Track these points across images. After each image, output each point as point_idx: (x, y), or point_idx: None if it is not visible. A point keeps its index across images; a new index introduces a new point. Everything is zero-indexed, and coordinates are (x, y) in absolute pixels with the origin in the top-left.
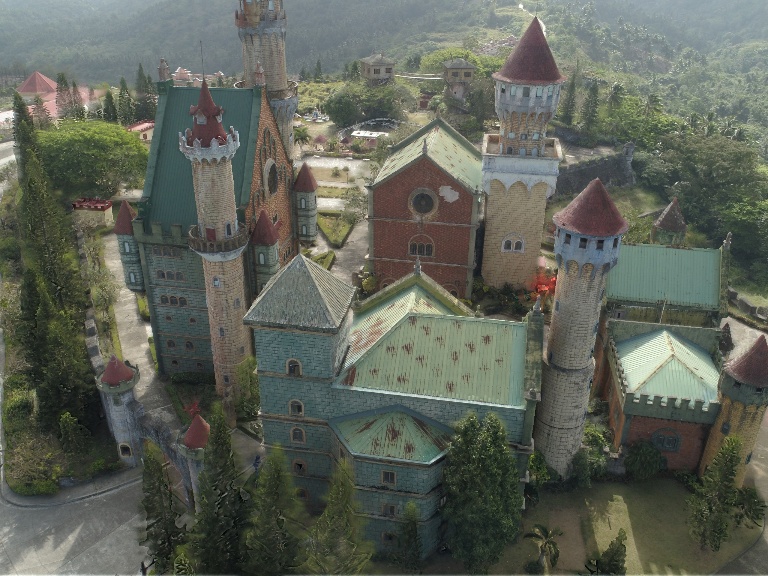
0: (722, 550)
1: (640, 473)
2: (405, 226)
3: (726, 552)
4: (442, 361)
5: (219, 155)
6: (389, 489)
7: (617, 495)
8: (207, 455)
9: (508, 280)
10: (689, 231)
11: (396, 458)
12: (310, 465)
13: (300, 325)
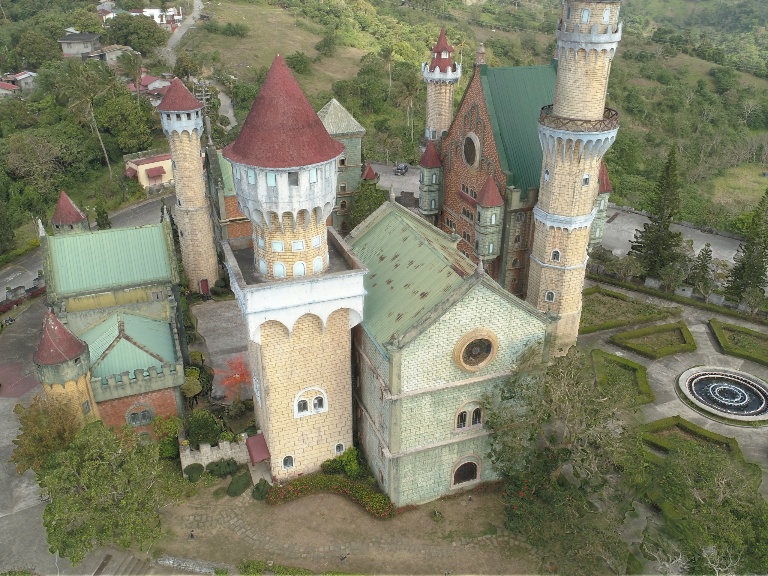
0: None
1: None
2: None
3: None
4: None
5: None
6: None
7: None
8: None
9: None
10: None
11: None
12: None
13: None
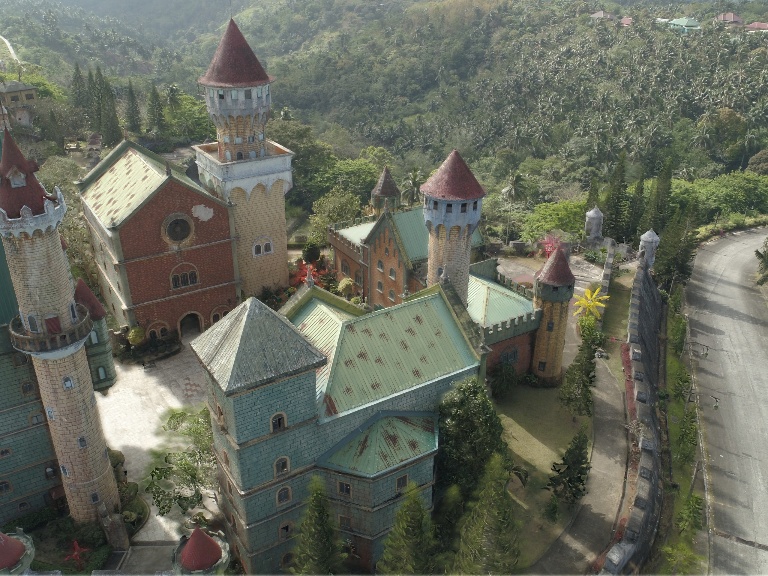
0: (583, 416)
1: (509, 389)
2: (162, 260)
3: (586, 416)
4: (397, 354)
5: (55, 220)
6: (402, 494)
7: (500, 415)
8: (319, 540)
9: (264, 284)
10: (287, 207)
11: (409, 459)
12: (297, 522)
13: (290, 371)
